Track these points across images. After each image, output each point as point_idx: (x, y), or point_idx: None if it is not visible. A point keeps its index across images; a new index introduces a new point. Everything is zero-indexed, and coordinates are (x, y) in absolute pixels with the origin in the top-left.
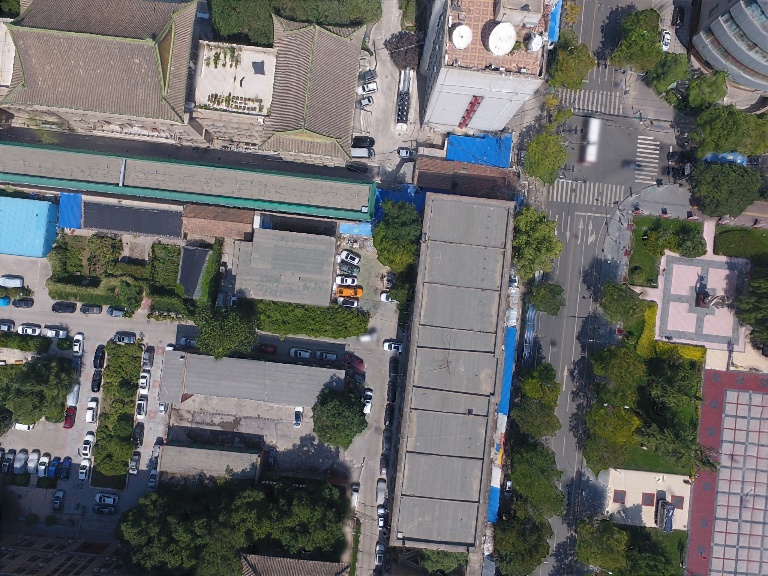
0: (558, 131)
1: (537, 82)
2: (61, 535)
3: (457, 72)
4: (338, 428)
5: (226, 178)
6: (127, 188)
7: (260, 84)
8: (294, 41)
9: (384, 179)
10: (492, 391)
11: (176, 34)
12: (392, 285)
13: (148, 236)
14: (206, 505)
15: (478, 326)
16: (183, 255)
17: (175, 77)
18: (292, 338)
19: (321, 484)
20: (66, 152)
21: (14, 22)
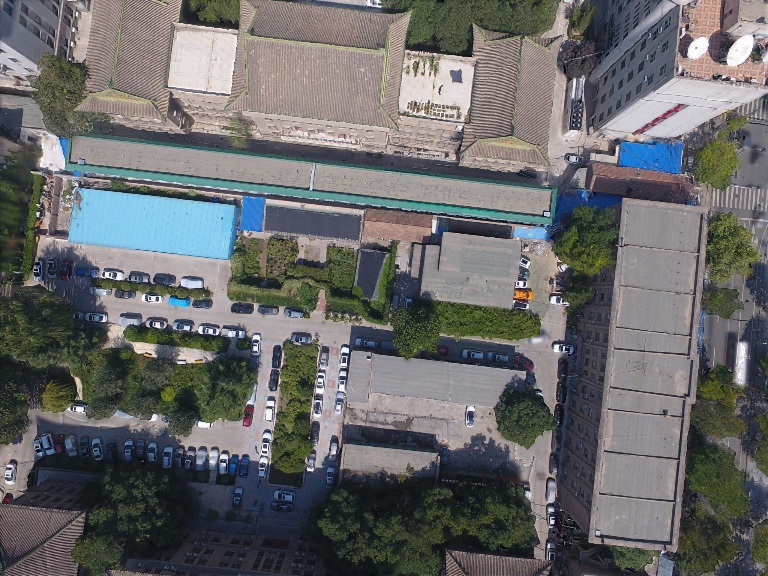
0: (731, 138)
1: (763, 92)
2: (240, 531)
3: (687, 82)
4: (534, 428)
5: (412, 183)
6: (317, 192)
7: (458, 92)
8: (496, 50)
9: (552, 184)
10: (686, 392)
11: (391, 44)
12: (568, 288)
13: (326, 239)
14: (392, 502)
15: (672, 329)
16: (360, 258)
17: (390, 85)
18: (463, 339)
19: (502, 483)
20: (258, 157)
21: (248, 32)
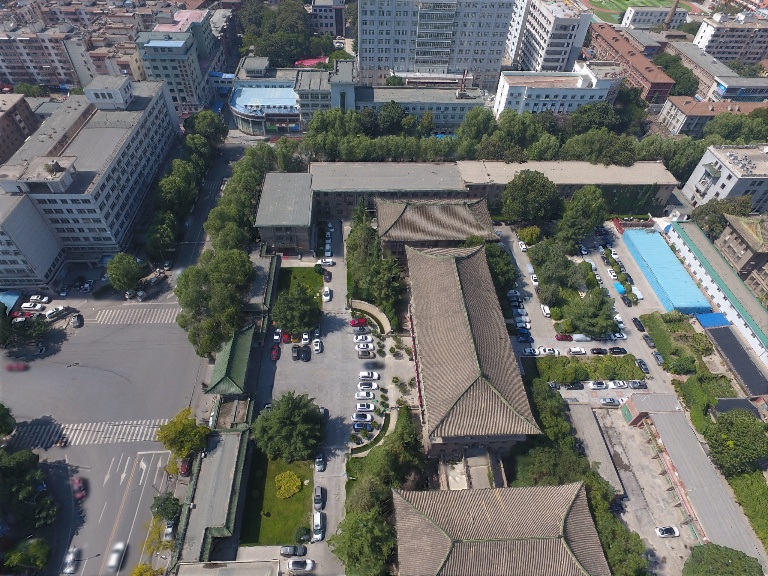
0: None
1: None
2: None
3: None
4: (746, 572)
5: None
6: None
7: None
8: None
9: None
10: None
11: None
12: None
13: (734, 372)
14: None
15: None
16: (741, 399)
17: None
18: None
19: None
20: (766, 311)
21: None
